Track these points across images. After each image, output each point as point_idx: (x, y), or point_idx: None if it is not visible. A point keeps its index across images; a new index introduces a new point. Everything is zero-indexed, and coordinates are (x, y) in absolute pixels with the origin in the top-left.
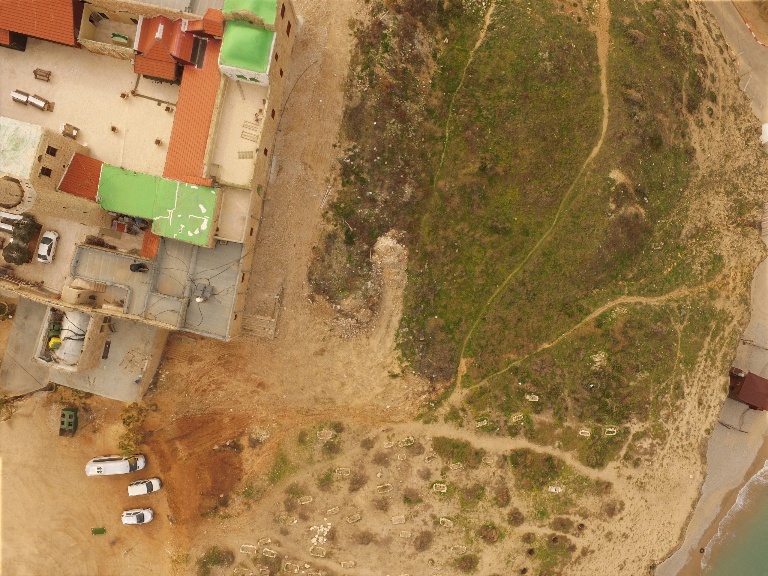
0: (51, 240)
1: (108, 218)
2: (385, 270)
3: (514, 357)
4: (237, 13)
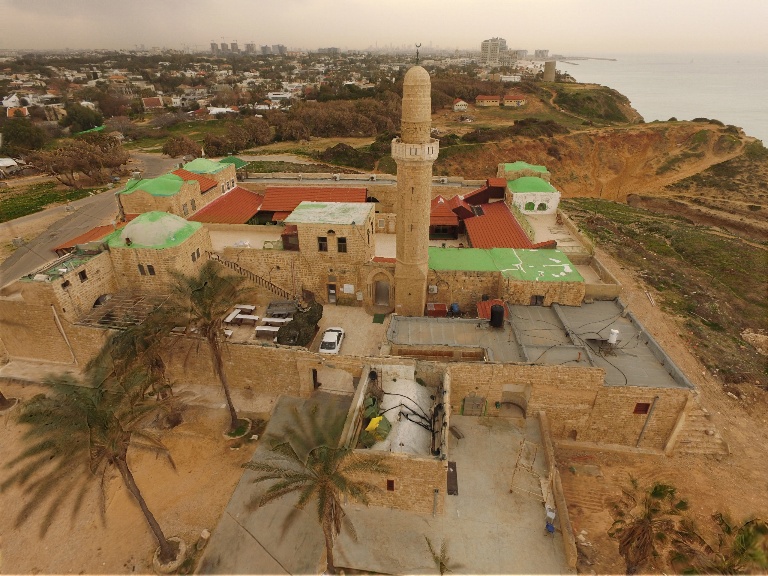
0: (339, 331)
1: (425, 296)
2: None
3: None
4: (517, 172)
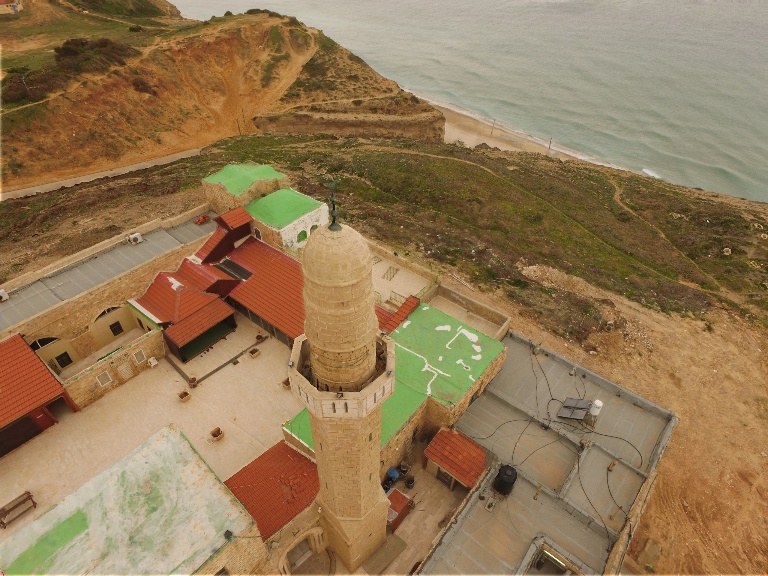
0: None
1: None
2: (562, 285)
3: (676, 254)
4: (249, 191)
